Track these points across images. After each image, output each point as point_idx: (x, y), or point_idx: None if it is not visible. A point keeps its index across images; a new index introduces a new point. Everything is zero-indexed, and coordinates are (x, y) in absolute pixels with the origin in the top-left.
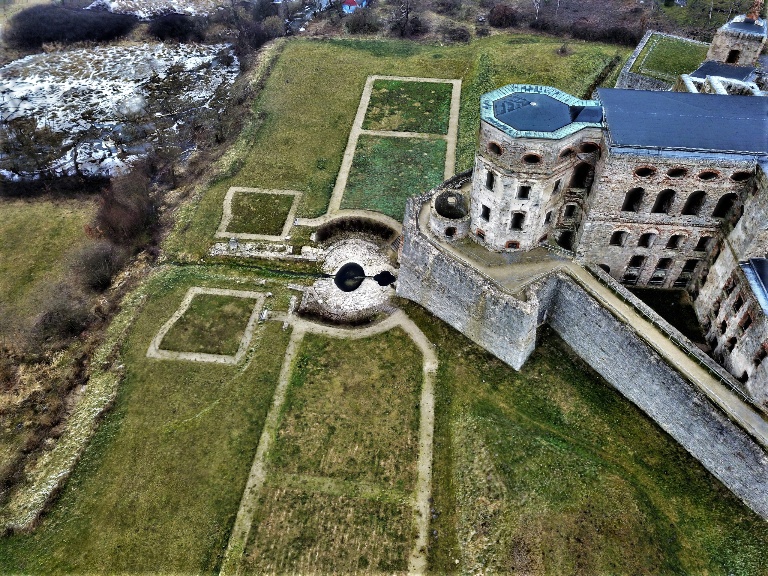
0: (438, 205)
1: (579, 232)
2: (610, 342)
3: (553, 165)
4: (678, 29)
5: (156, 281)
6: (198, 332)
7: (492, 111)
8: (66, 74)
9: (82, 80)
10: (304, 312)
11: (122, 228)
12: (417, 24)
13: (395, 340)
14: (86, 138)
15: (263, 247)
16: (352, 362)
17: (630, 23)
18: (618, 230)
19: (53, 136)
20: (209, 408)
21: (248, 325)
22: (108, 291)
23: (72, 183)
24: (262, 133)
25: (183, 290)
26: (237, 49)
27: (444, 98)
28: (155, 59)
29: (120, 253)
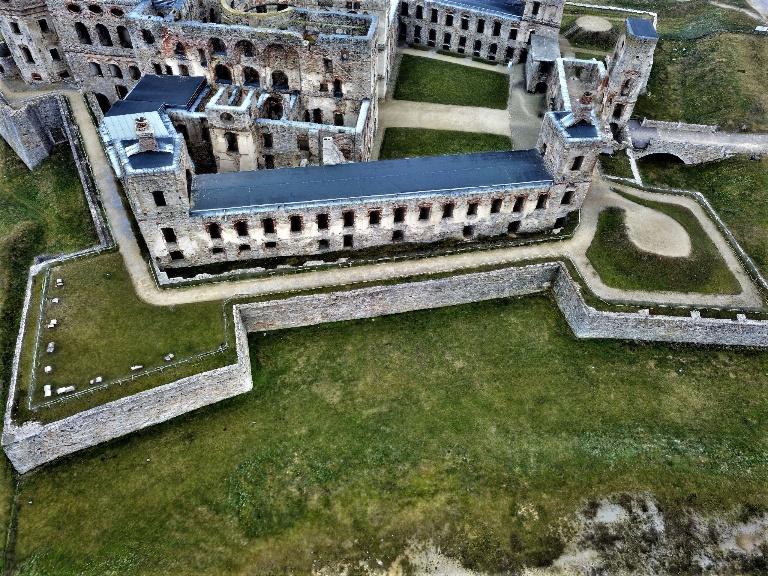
0: (7, 52)
1: None
2: None
3: (23, 4)
4: None
5: None
6: None
7: None
8: None
9: None
10: None
11: None
12: None
13: None
14: None
15: None
16: None
17: None
18: (90, 61)
19: None
20: None
21: None
22: None
23: None
24: None
25: None
26: None
27: None
28: None
29: None
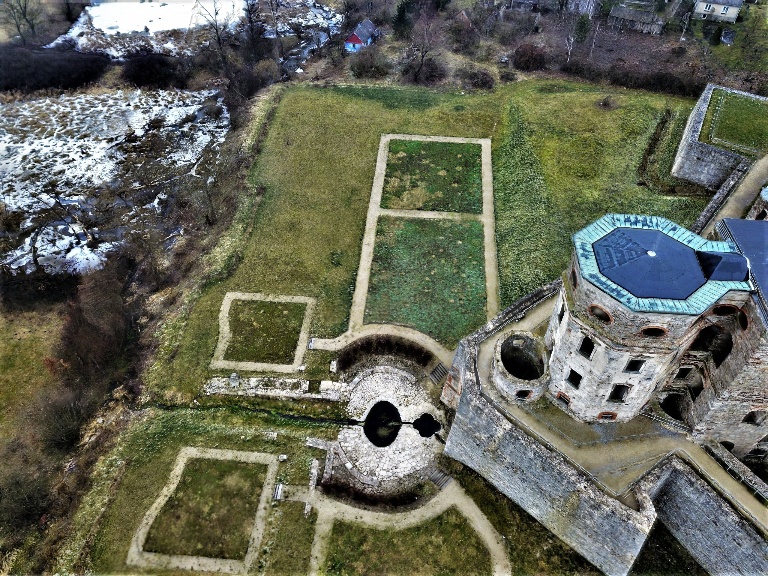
0: (502, 350)
1: (699, 405)
2: (755, 568)
3: None
4: (730, 74)
5: (137, 437)
6: (194, 521)
7: (595, 262)
8: (25, 132)
9: (44, 139)
10: (330, 484)
11: (93, 360)
12: (433, 68)
13: (451, 530)
14: (49, 219)
15: (272, 383)
16: (399, 569)
17: (675, 66)
18: (757, 410)
19: (8, 218)
20: None
21: (259, 508)
22: (76, 449)
23: (30, 292)
24: (262, 215)
25: (172, 453)
26: (226, 97)
27: (473, 164)
28: (131, 110)
29: (91, 396)
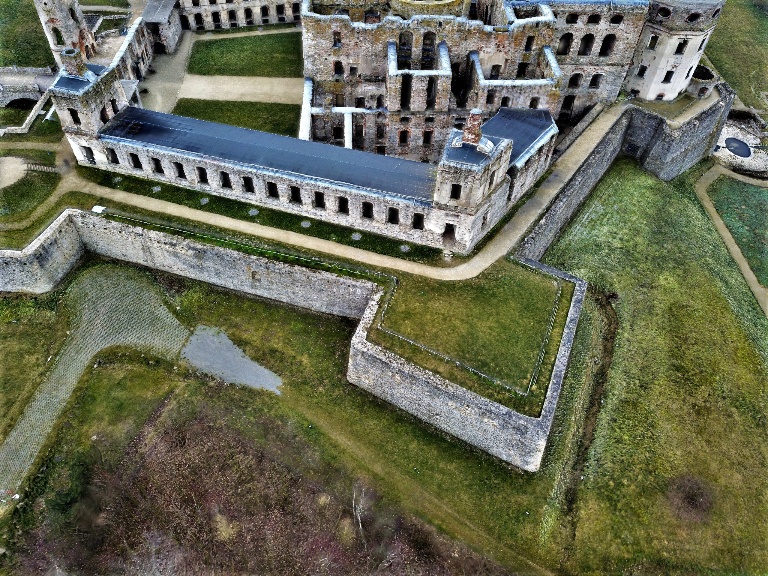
0: None
1: None
2: None
3: None
4: None
5: None
6: None
7: None
8: None
9: None
10: (748, 119)
11: None
12: None
13: None
14: None
15: None
16: None
17: None
18: None
19: None
20: (752, 74)
21: None
22: None
23: None
24: None
25: None
26: None
27: None
28: None
29: None
